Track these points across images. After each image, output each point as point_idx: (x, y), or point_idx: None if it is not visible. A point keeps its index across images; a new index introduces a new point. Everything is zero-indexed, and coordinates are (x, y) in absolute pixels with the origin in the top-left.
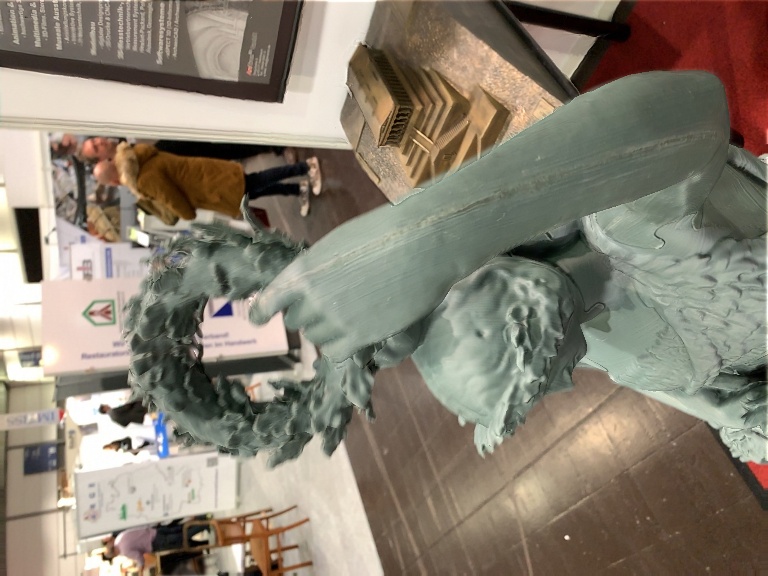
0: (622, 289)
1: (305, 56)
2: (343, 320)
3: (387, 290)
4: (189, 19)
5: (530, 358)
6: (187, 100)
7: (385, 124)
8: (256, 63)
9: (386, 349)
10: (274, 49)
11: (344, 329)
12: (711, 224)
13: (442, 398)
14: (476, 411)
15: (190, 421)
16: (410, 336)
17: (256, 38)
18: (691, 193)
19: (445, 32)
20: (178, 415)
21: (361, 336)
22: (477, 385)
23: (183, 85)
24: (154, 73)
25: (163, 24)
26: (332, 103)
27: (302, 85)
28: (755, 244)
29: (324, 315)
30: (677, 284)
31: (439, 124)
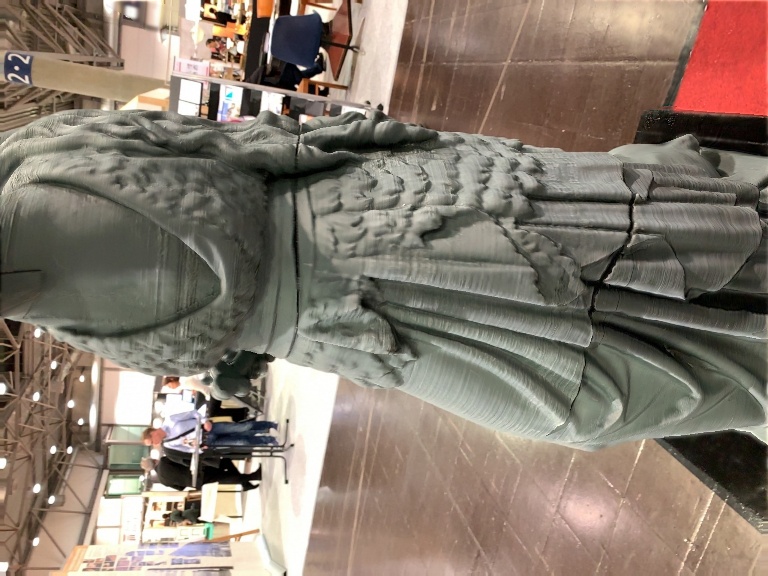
0: None
1: None
2: None
3: None
4: None
5: None
6: None
7: None
8: None
9: None
10: None
11: None
12: (45, 316)
13: None
14: None
15: None
16: None
17: None
18: None
19: None
20: None
21: None
22: None
23: None
24: None
25: None
26: None
27: None
28: (93, 341)
29: None
30: None
31: None
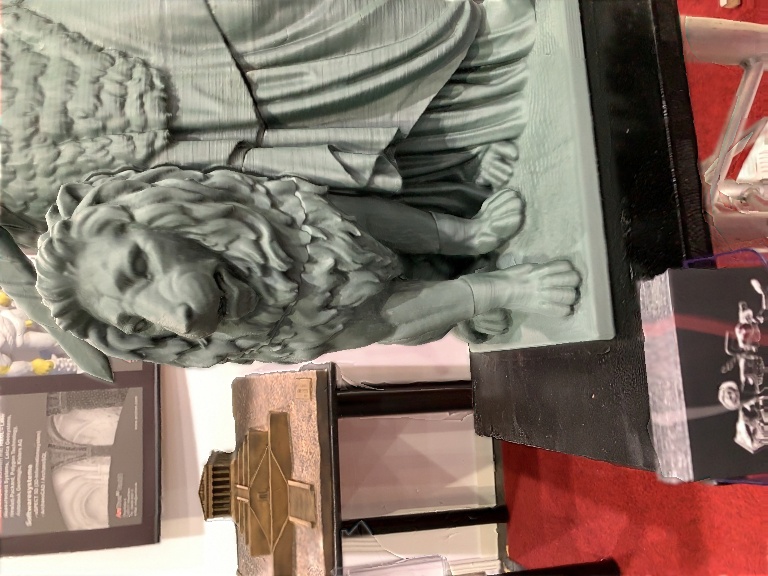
0: None
1: (188, 495)
2: None
3: None
4: (55, 473)
5: None
6: (69, 570)
7: (202, 489)
8: (125, 504)
9: None
10: (142, 486)
11: None
12: None
13: None
14: None
15: None
16: None
17: (122, 479)
18: None
19: (247, 392)
20: None
21: None
22: None
23: (55, 546)
24: (24, 537)
25: (31, 484)
26: (235, 545)
27: (193, 528)
28: None
29: None
30: None
31: (247, 465)
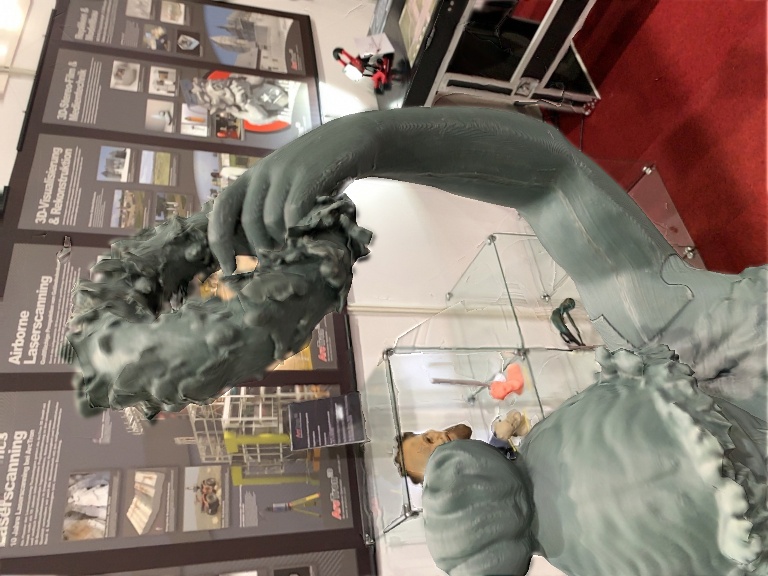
0: (754, 397)
1: None
2: (287, 163)
3: (316, 135)
4: None
5: (644, 366)
6: None
7: None
8: None
9: (471, 477)
10: None
11: (291, 167)
12: None
13: (616, 524)
14: (660, 472)
15: (138, 327)
16: (492, 449)
17: None
18: (608, 192)
19: None
20: (122, 332)
21: (310, 167)
22: (615, 426)
23: None
24: None
25: None
26: None
27: None
28: None
29: (270, 169)
30: (761, 316)
31: None
